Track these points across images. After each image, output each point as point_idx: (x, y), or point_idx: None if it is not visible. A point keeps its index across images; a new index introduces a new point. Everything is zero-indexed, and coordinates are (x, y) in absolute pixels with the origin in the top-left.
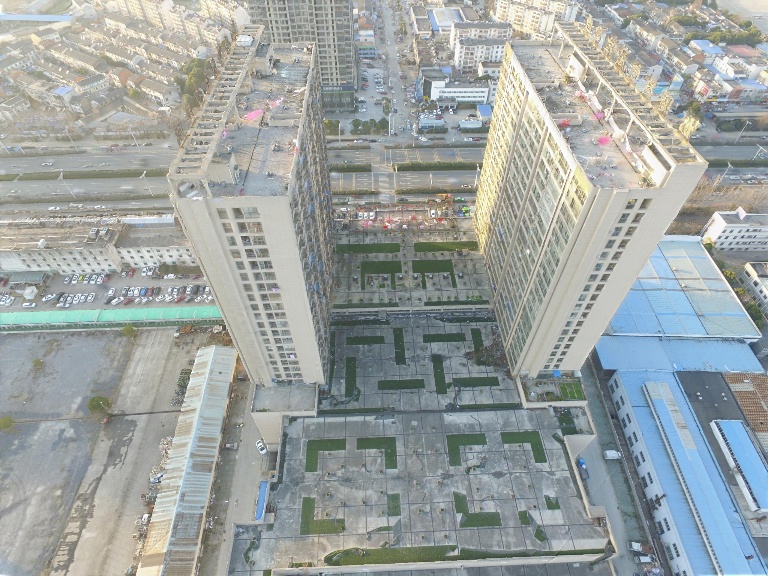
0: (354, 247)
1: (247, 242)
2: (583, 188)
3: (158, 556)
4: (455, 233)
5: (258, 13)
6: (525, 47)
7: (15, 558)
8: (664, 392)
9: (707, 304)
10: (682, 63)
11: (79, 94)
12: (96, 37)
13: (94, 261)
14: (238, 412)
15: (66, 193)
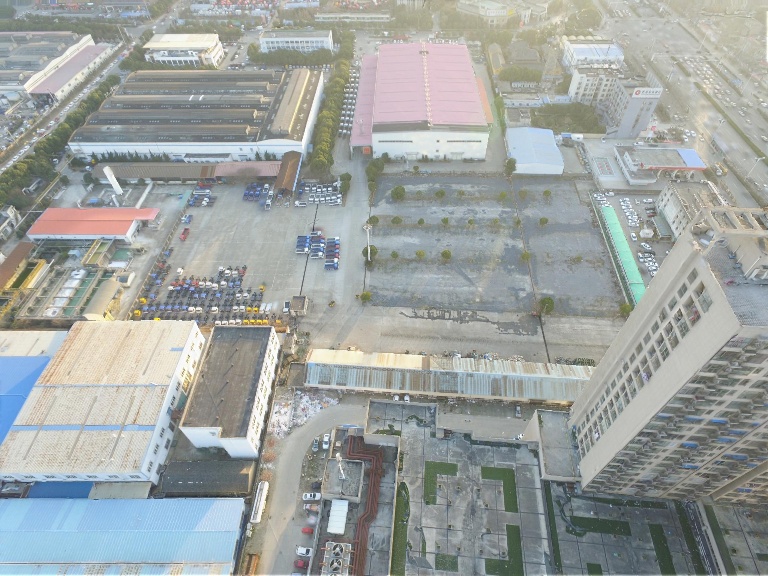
0: None
1: (678, 318)
2: None
3: (428, 366)
4: None
5: None
6: None
7: (437, 290)
8: None
9: None
10: None
11: None
12: None
13: None
14: None
15: None
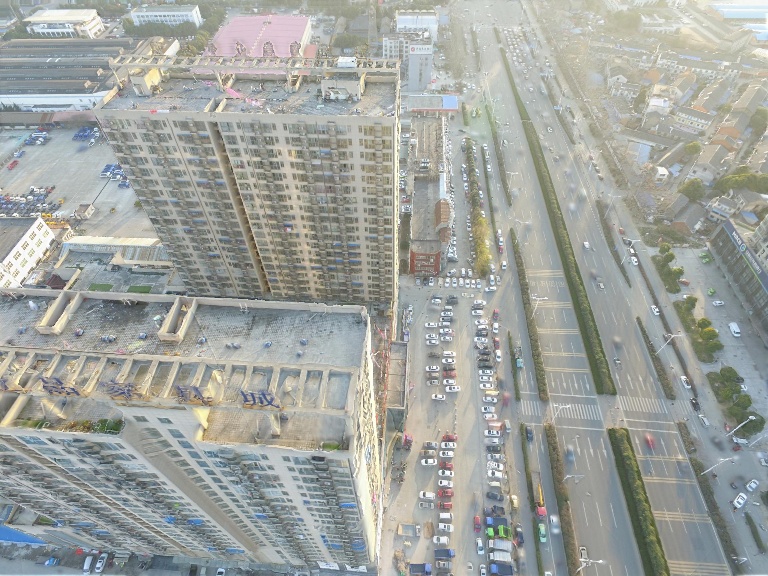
0: None
1: None
2: None
3: (157, 244)
4: None
5: None
6: (359, 345)
7: None
8: None
9: None
10: None
11: (666, 114)
12: None
13: None
14: None
15: (508, 148)
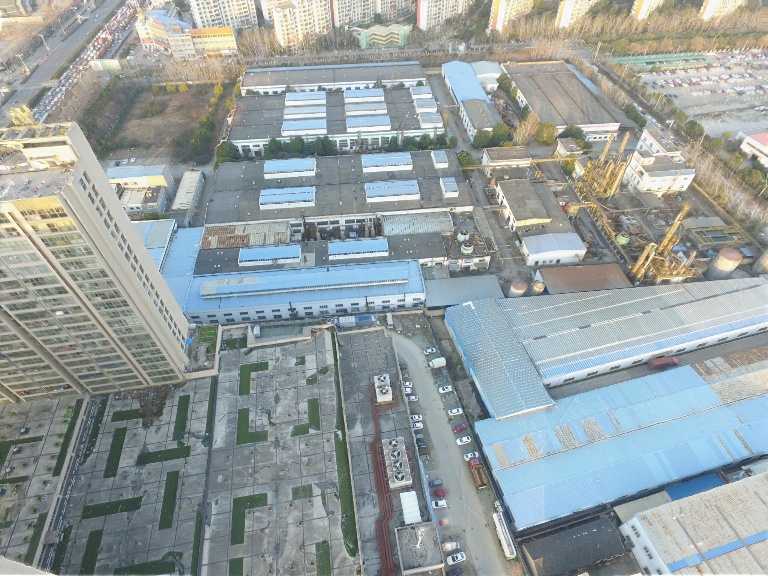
0: None
1: None
2: (47, 207)
3: None
4: None
5: None
6: None
7: None
8: (211, 284)
9: None
10: None
11: None
12: None
13: None
14: None
15: None
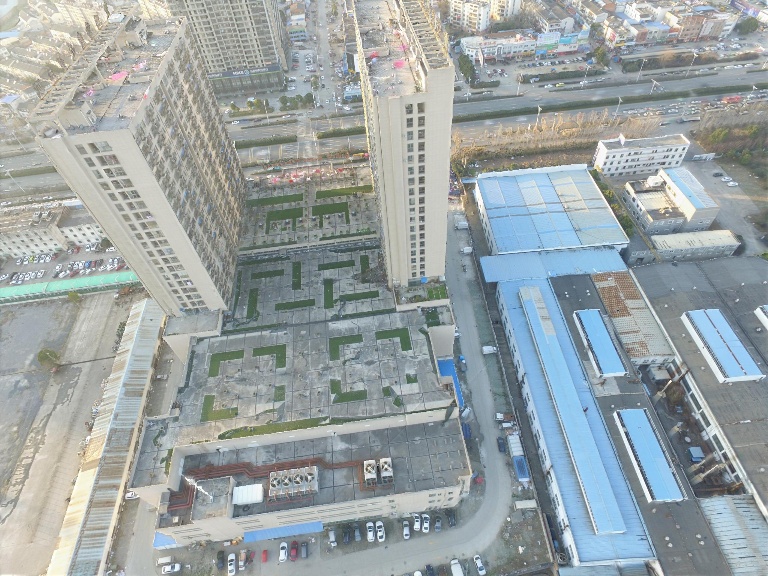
0: (262, 201)
1: (111, 174)
2: None
3: (95, 461)
4: (353, 180)
5: (177, 5)
6: (369, 1)
7: None
8: (534, 294)
9: (585, 220)
10: (593, 13)
11: (26, 101)
12: (43, 48)
13: (41, 242)
14: (168, 351)
15: (17, 189)
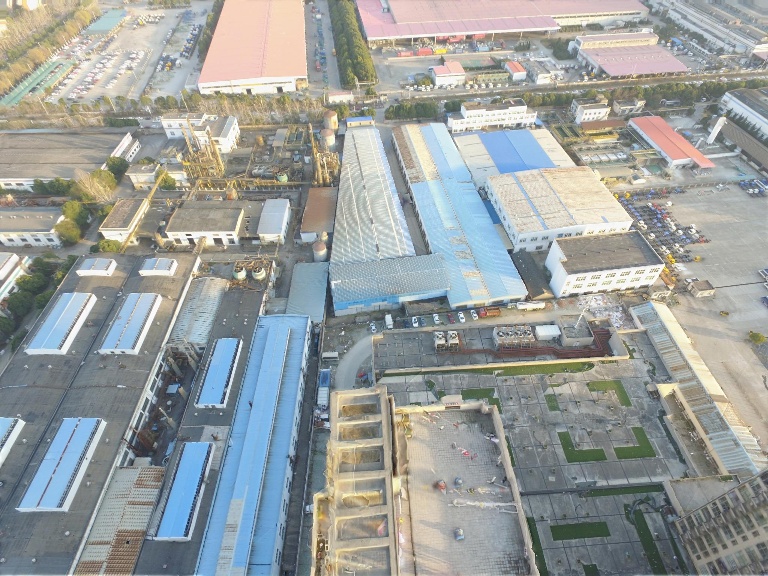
0: None
1: None
2: None
3: (717, 400)
4: None
5: None
6: None
7: None
8: None
9: None
10: None
11: None
12: None
13: None
14: None
15: None
